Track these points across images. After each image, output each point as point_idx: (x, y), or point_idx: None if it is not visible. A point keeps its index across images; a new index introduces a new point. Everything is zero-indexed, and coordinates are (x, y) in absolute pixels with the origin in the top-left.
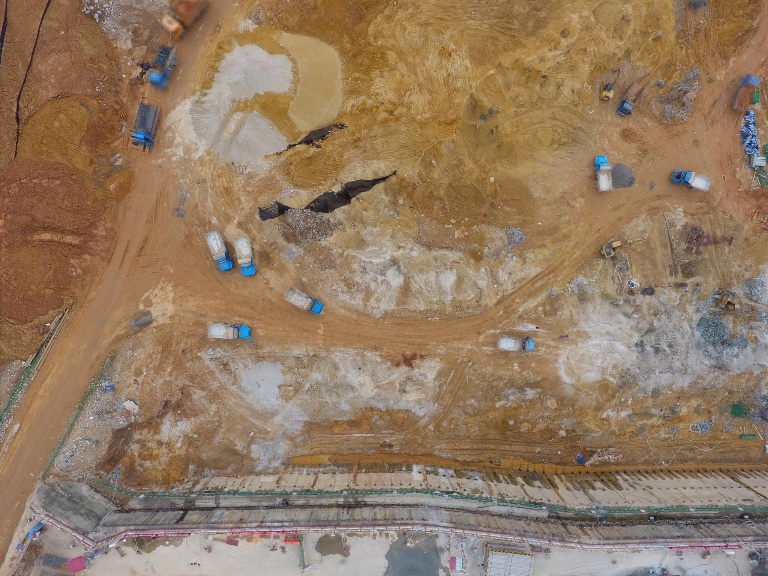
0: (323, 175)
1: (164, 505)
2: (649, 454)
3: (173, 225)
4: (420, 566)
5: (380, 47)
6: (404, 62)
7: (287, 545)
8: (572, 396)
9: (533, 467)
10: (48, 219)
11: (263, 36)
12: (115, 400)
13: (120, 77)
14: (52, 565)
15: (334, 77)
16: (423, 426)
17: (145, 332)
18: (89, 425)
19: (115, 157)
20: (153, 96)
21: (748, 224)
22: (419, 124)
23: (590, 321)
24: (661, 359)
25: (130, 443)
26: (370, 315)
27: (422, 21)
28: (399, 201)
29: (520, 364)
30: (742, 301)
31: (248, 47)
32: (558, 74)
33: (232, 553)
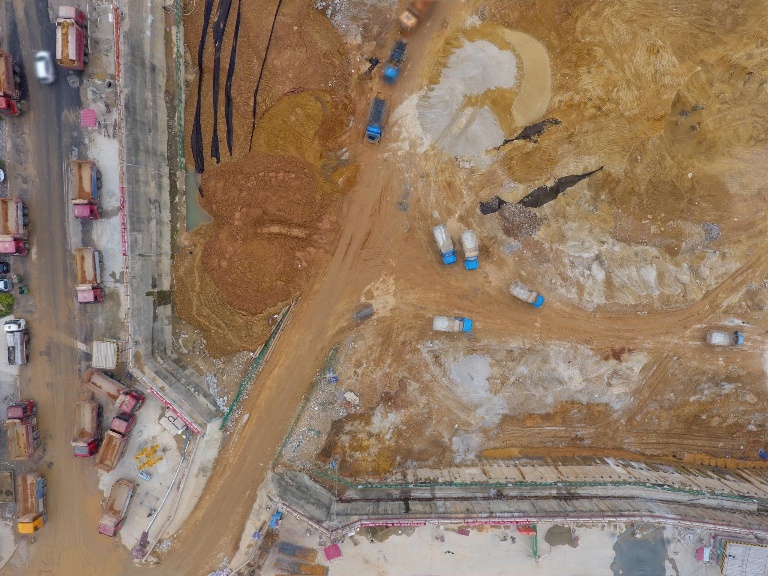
0: (539, 170)
1: (381, 495)
2: None
3: (396, 219)
4: (647, 557)
5: (588, 43)
6: (612, 58)
7: (517, 535)
8: None
9: (715, 462)
10: (279, 212)
11: (490, 32)
12: (336, 391)
13: (350, 72)
14: (287, 553)
15: (546, 73)
16: (615, 420)
17: (366, 324)
18: (314, 416)
19: (342, 151)
20: (381, 91)
21: None
22: (627, 120)
23: None
24: None
25: (340, 434)
26: (583, 309)
27: (627, 18)
28: (601, 196)
29: (725, 358)
30: None
31: (480, 43)
32: (763, 71)
33: (463, 543)
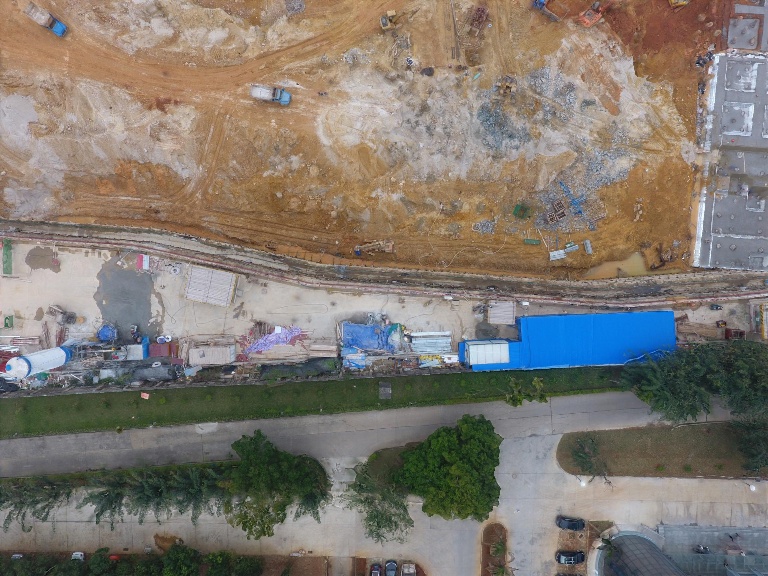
0: None
1: None
2: (429, 252)
3: None
4: (132, 289)
5: None
6: None
7: None
8: (337, 167)
9: (310, 256)
10: None
11: None
12: None
13: None
14: None
15: None
16: (190, 193)
17: None
18: None
19: None
20: None
21: (535, 12)
22: None
23: (352, 82)
24: (436, 142)
25: None
26: (122, 50)
27: None
28: None
29: (278, 121)
30: (526, 93)
31: None
32: None
33: None
